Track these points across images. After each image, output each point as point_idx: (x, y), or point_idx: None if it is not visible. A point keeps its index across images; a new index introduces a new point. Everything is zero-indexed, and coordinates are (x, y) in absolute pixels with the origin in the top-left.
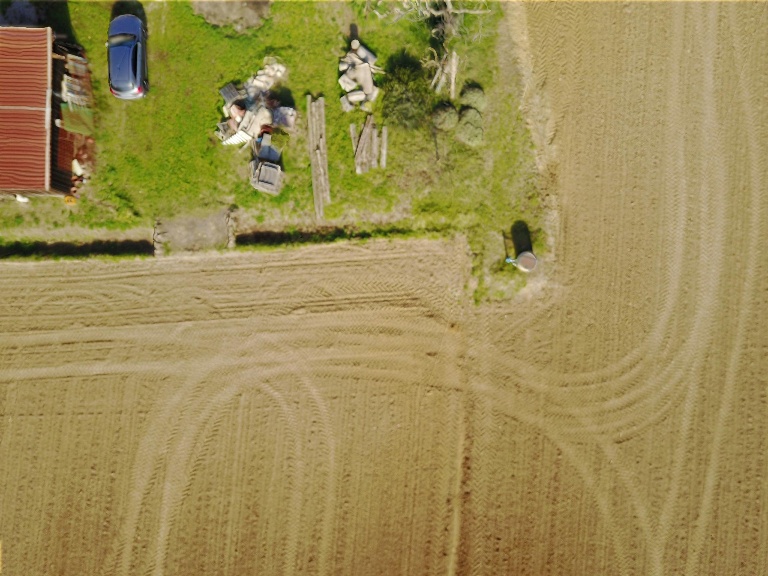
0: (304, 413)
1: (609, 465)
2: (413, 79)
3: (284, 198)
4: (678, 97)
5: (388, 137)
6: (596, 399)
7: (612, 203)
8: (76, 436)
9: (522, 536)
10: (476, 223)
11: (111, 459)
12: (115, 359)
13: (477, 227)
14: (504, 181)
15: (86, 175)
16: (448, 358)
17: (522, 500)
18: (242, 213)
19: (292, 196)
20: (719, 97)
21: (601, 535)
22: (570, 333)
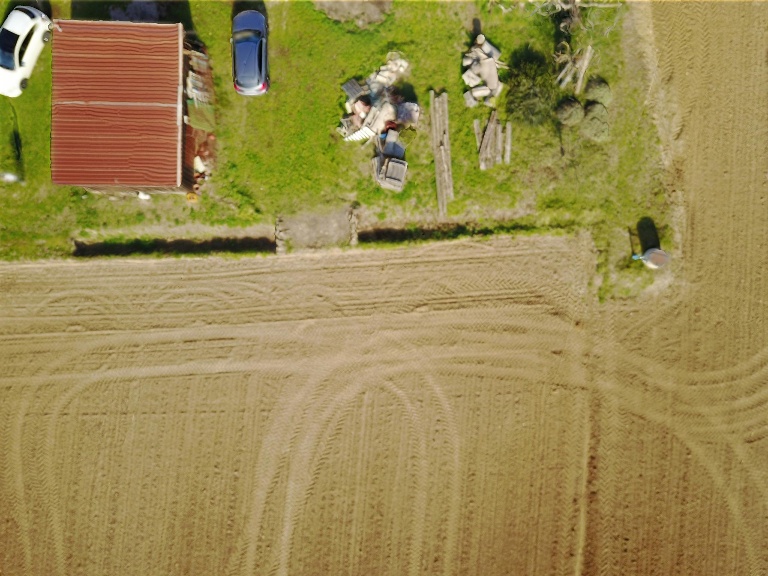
0: (428, 412)
1: (740, 465)
2: (540, 74)
3: (406, 195)
4: None
5: (512, 133)
6: (726, 398)
7: (741, 199)
8: (199, 434)
9: (651, 537)
10: (601, 219)
11: (234, 458)
12: (237, 357)
13: (602, 224)
14: (630, 177)
15: (207, 172)
16: (573, 356)
17: (650, 500)
18: (364, 210)
19: (414, 193)
20: None
21: (732, 536)
22: (698, 331)
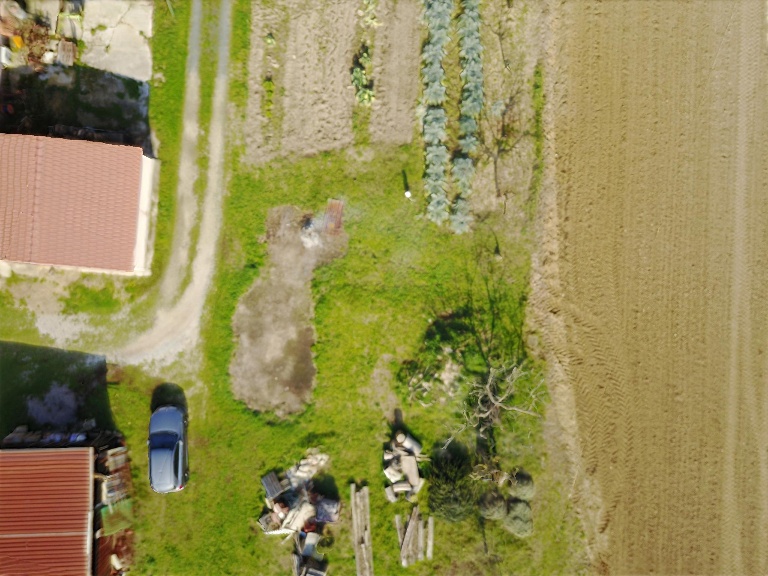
0: None
1: None
2: (461, 476)
3: None
4: (734, 491)
5: (435, 527)
6: None
7: None
8: None
9: None
10: None
11: None
12: None
13: None
14: (555, 572)
15: (125, 567)
16: None
17: None
18: None
19: None
20: None
21: None
22: None
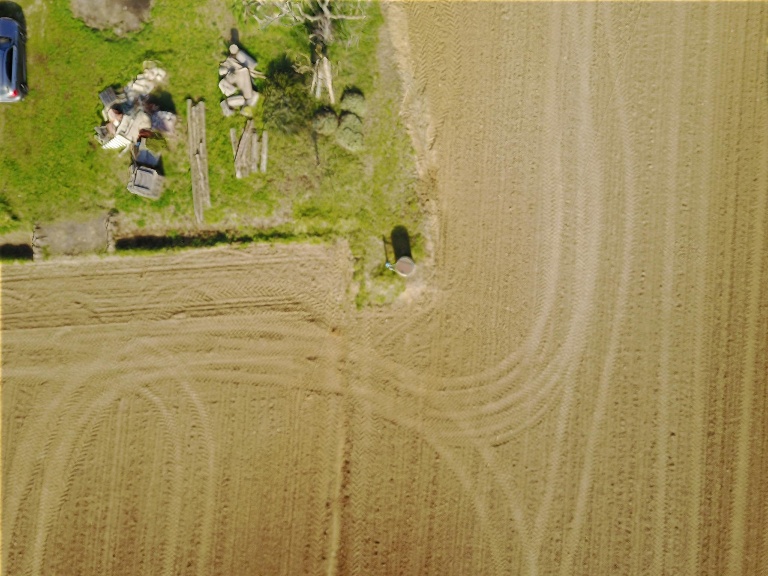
0: (183, 418)
1: (486, 468)
2: (291, 84)
3: (164, 202)
4: (555, 103)
5: (268, 142)
6: (474, 403)
7: (491, 208)
8: None
9: (400, 539)
10: (357, 228)
11: None
12: None
13: (358, 232)
14: (384, 186)
15: None
16: (328, 362)
17: (401, 504)
18: (122, 217)
19: (173, 200)
20: (595, 104)
21: (478, 538)
22: (449, 337)
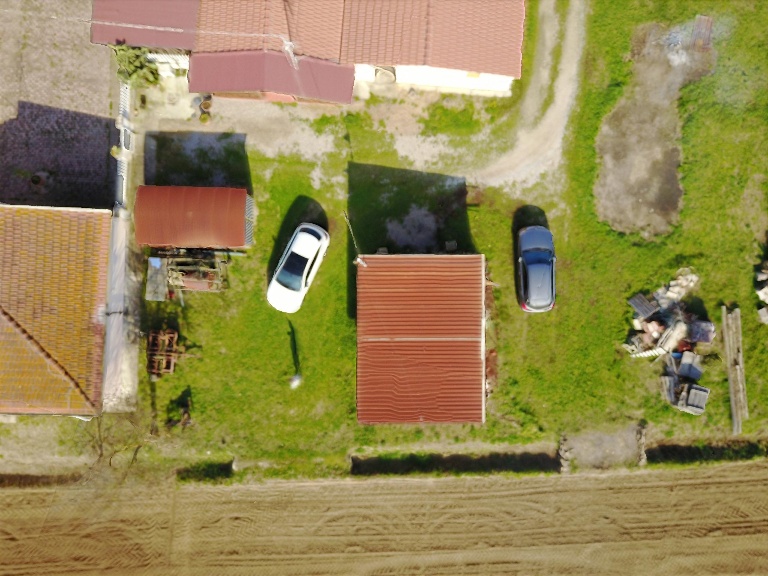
0: None
1: None
2: None
3: None
4: None
5: None
6: None
7: None
8: None
9: None
10: None
11: None
12: None
13: None
14: None
15: (489, 389)
16: None
17: None
18: (651, 428)
19: (705, 411)
20: None
21: None
22: None
